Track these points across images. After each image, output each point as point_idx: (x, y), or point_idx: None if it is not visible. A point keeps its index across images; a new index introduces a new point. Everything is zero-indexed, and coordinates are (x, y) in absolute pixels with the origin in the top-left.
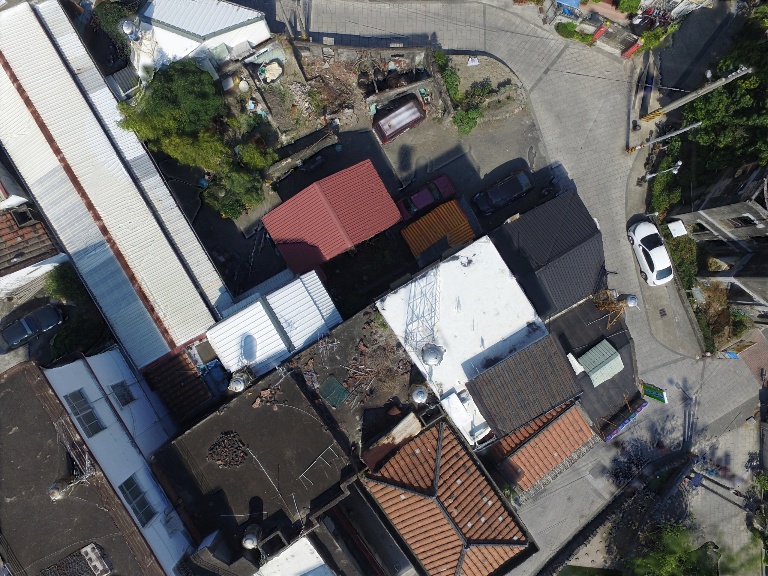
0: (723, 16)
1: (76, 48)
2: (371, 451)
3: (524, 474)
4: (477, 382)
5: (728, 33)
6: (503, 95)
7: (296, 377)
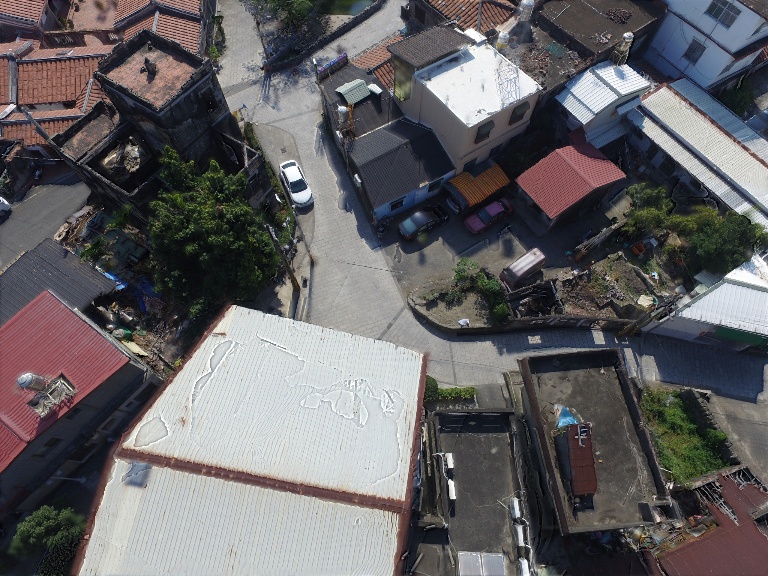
0: None
1: None
2: None
3: None
4: None
5: None
6: None
7: (585, 54)
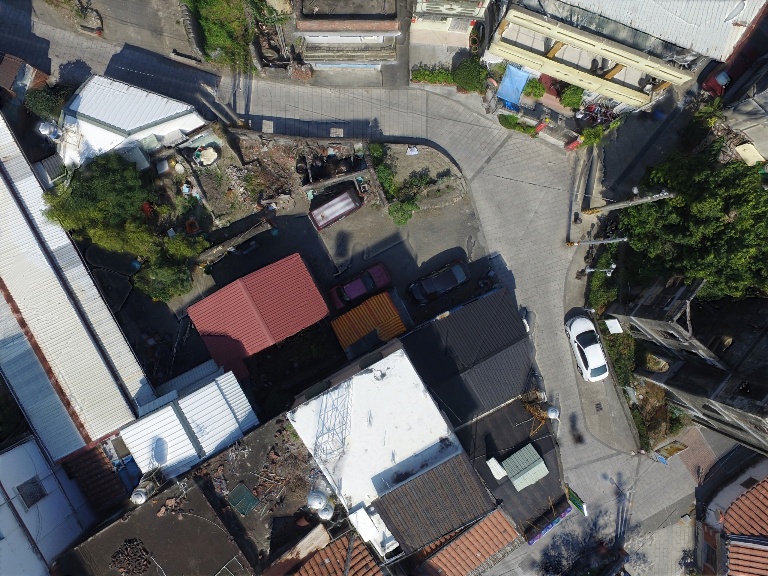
0: (670, 110)
1: (3, 136)
2: (272, 568)
3: (445, 574)
4: (384, 501)
5: (674, 128)
6: (443, 184)
7: (204, 484)
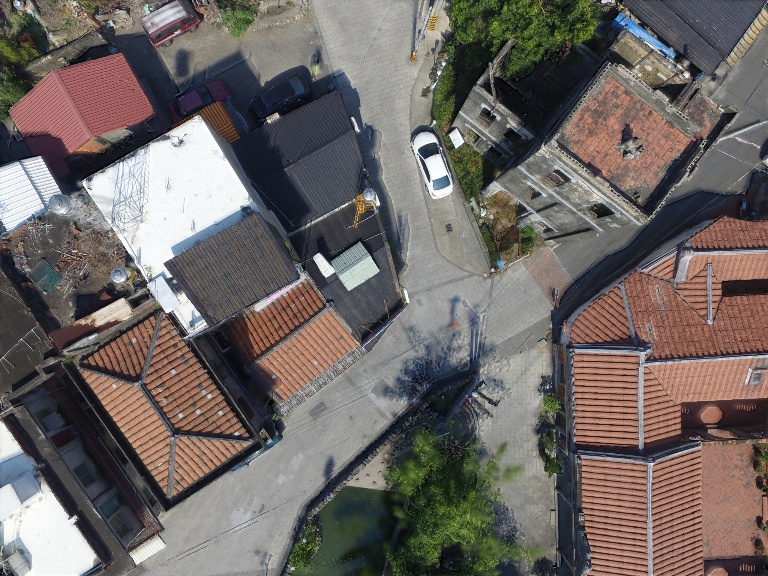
0: None
1: None
2: (62, 330)
3: (281, 382)
4: (177, 262)
5: None
6: (283, 0)
7: (3, 258)
